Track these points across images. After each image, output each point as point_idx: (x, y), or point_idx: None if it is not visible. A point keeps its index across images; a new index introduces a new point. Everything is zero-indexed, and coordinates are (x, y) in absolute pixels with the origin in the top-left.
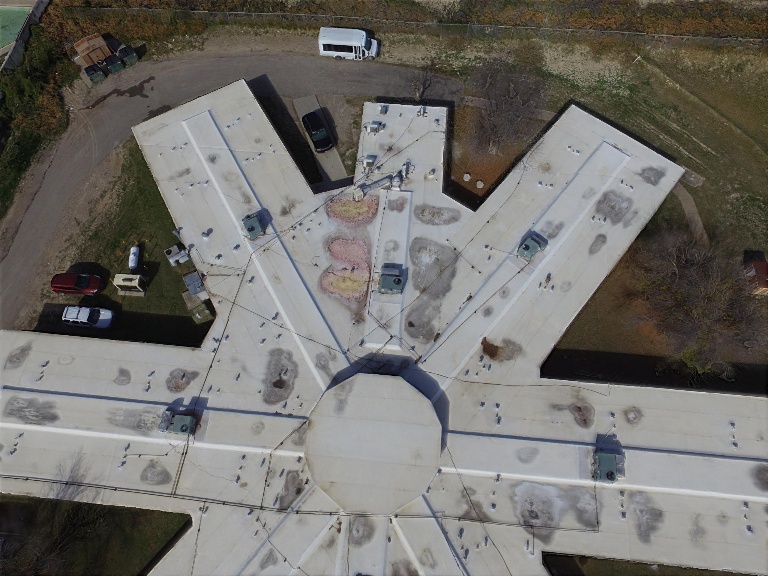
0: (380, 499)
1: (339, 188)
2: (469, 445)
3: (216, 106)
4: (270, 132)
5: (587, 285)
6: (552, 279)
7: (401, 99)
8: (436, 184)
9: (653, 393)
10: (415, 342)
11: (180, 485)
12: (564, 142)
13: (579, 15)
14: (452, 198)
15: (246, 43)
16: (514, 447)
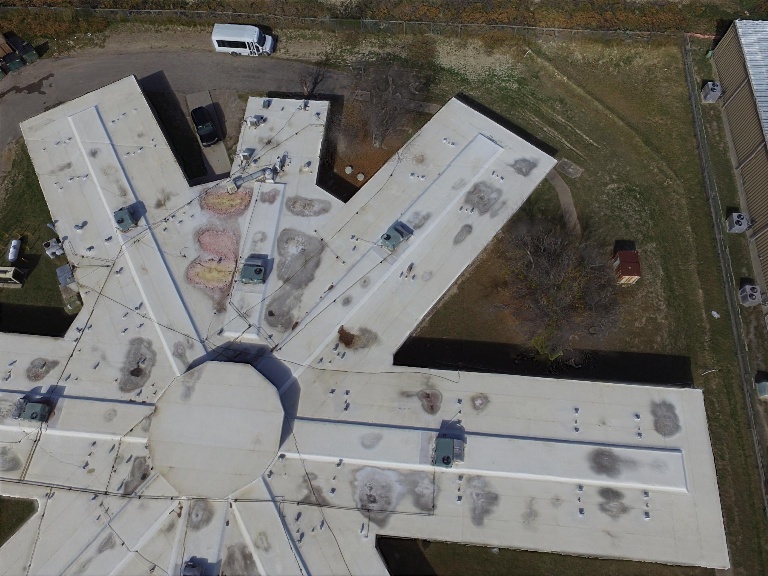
0: (216, 483)
1: (215, 181)
2: (314, 431)
3: (104, 101)
4: (153, 126)
5: (448, 274)
6: (414, 268)
7: (292, 94)
8: (310, 176)
9: (501, 379)
10: (273, 331)
11: (30, 471)
12: (440, 134)
13: (472, 10)
14: (324, 190)
15: (146, 40)
16: (358, 433)
